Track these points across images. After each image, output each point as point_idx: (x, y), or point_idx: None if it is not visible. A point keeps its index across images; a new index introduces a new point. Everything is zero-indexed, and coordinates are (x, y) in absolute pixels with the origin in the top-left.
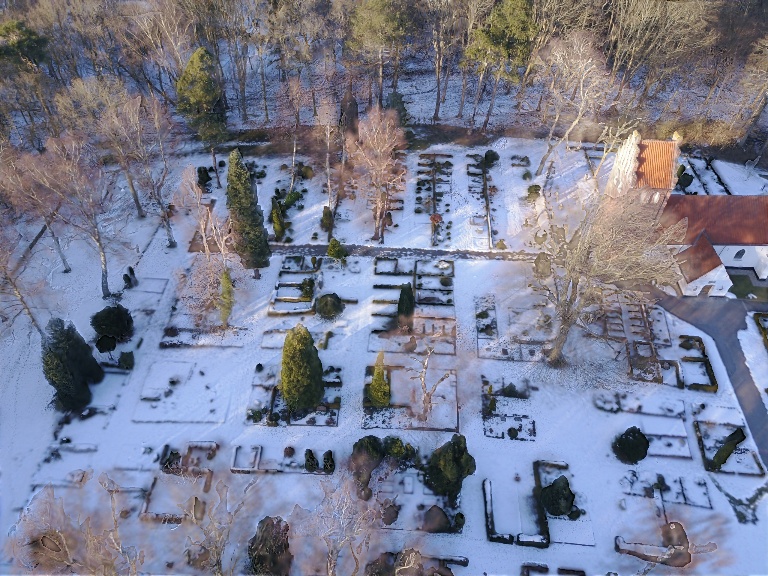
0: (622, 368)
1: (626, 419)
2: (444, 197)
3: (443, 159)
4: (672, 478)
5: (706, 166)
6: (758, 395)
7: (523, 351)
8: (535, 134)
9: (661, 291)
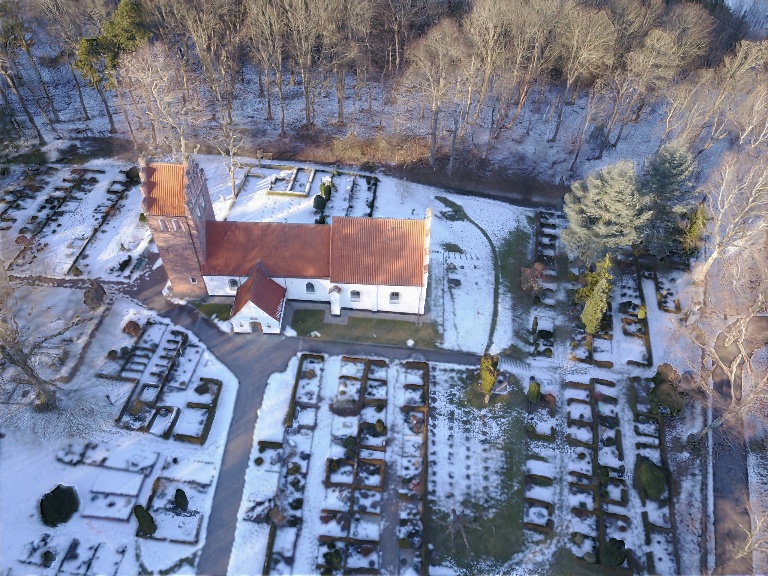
0: (113, 414)
1: (83, 473)
2: (64, 217)
3: (94, 175)
4: (90, 544)
5: (368, 187)
6: (248, 449)
7: (17, 392)
8: (210, 149)
9: (216, 326)
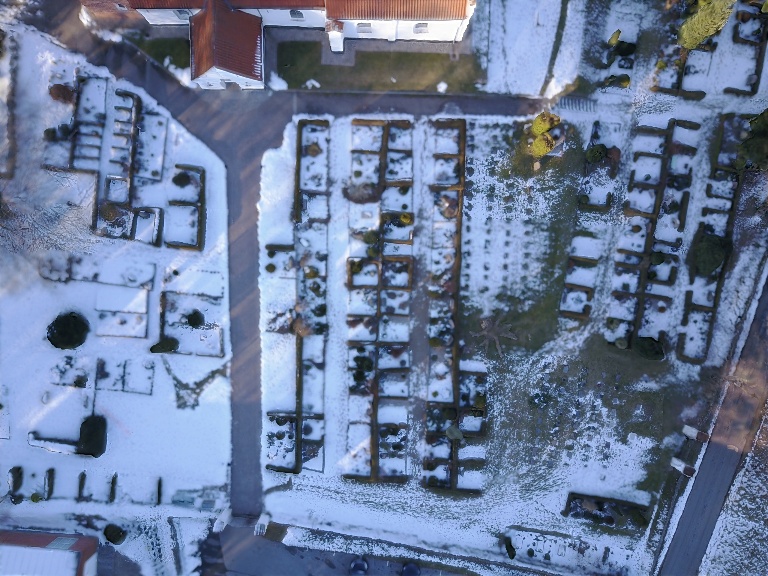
0: (84, 219)
1: (78, 290)
2: None
3: None
4: (115, 362)
5: None
6: (256, 253)
7: None
8: None
9: (174, 79)
